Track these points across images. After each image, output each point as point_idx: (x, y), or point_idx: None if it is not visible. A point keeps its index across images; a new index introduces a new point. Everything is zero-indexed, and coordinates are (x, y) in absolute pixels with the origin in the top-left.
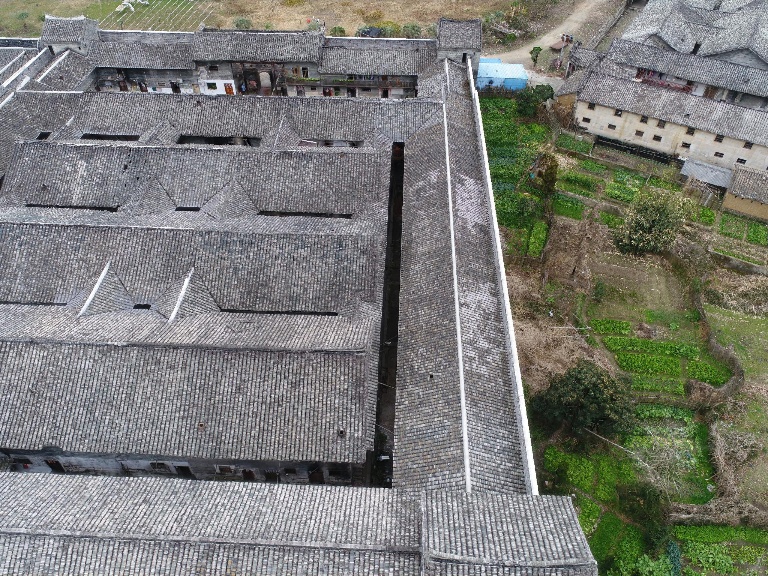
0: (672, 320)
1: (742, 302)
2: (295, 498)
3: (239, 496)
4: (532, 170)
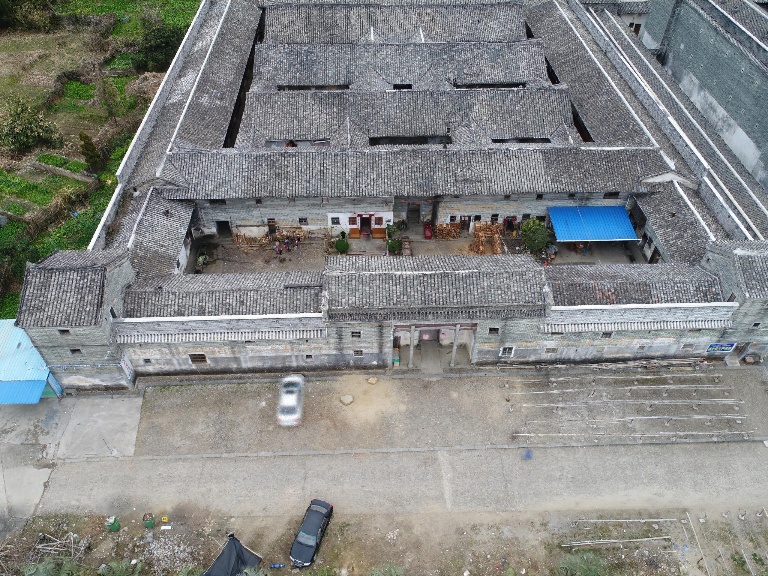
0: (69, 107)
1: (8, 113)
2: (299, 1)
3: (320, 1)
4: (92, 182)
